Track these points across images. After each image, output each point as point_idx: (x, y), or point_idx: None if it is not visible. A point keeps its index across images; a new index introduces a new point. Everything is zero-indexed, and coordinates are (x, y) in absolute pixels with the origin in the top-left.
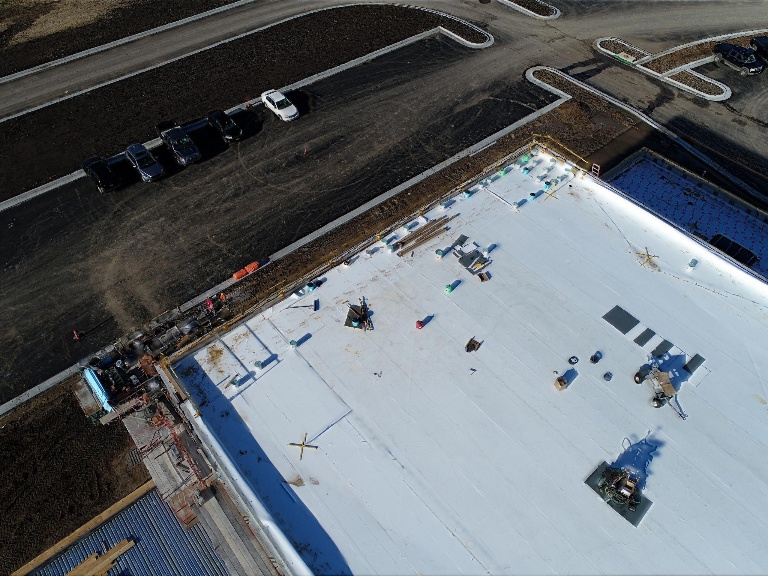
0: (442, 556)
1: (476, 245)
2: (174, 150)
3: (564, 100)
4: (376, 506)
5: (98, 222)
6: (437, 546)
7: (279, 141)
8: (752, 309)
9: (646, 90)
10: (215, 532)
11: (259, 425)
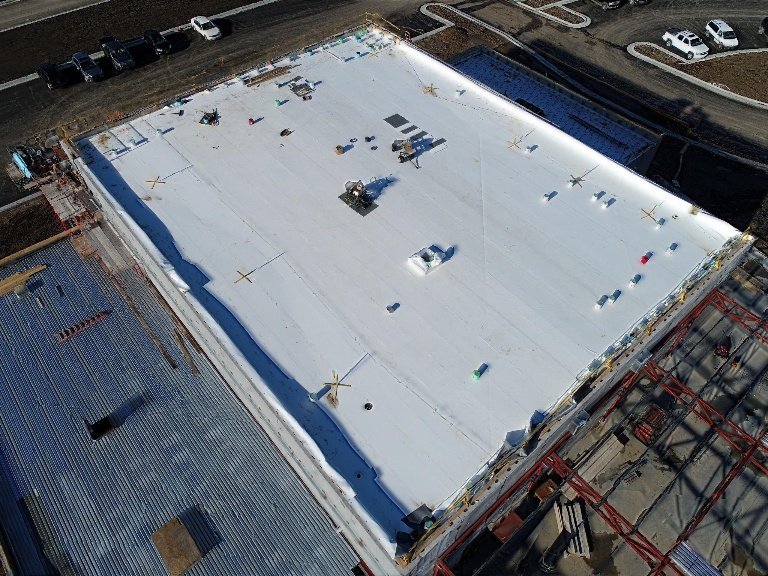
0: (234, 230)
1: (307, 81)
2: (112, 57)
3: (448, 26)
4: (197, 209)
5: (46, 109)
6: (232, 226)
7: (202, 54)
8: (492, 116)
9: (520, 20)
10: (97, 243)
11: (128, 173)
